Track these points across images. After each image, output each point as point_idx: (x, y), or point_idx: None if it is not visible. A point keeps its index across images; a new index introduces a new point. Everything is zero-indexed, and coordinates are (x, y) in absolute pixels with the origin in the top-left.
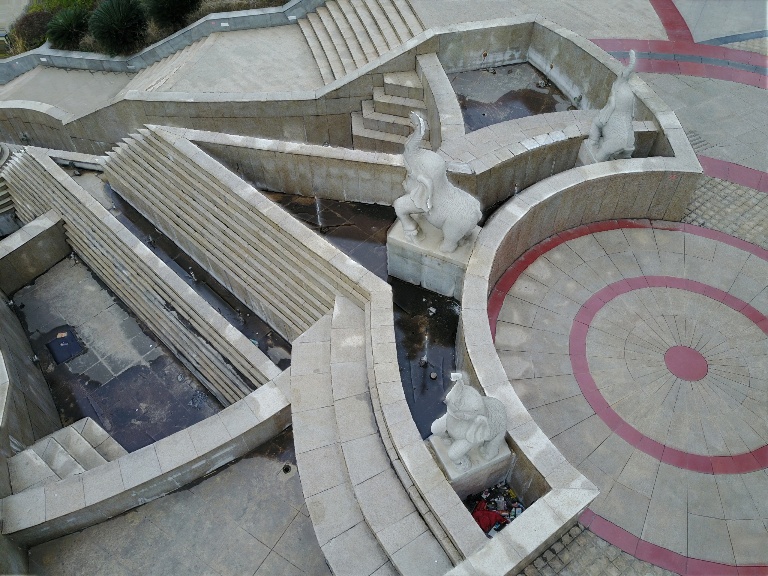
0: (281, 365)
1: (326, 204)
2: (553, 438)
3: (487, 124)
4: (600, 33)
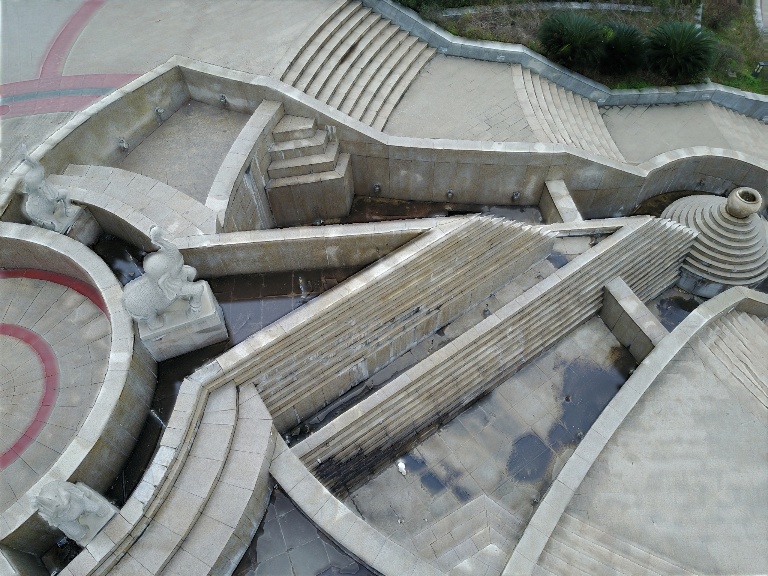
0: None
1: None
2: (37, 294)
3: None
4: None
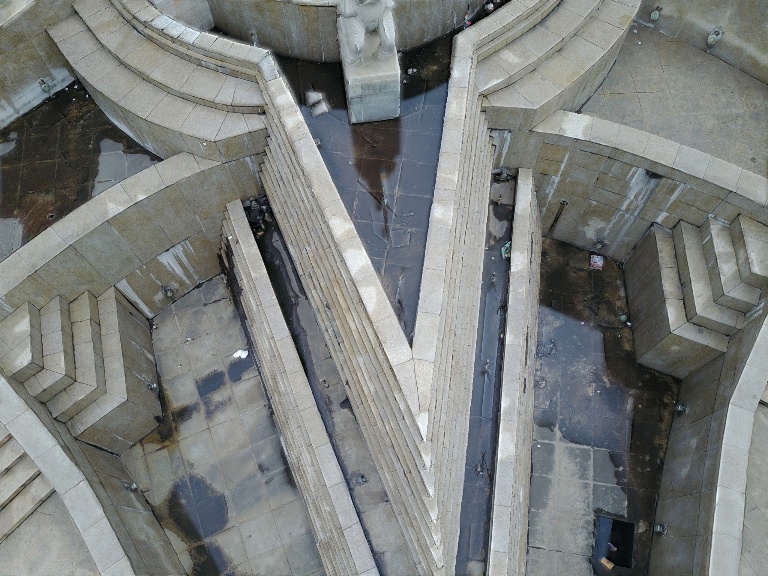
0: (505, 216)
1: None
2: None
3: (72, 203)
4: None
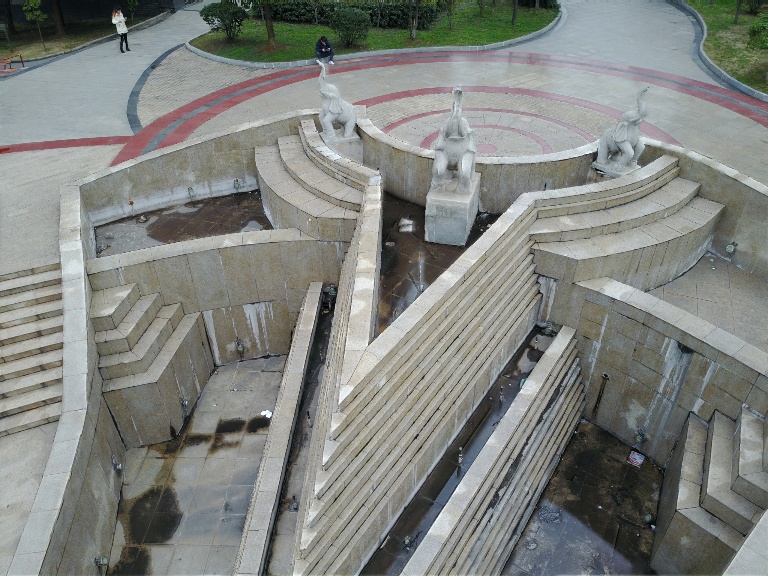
0: (537, 359)
1: (385, 294)
2: None
3: None
4: (96, 170)
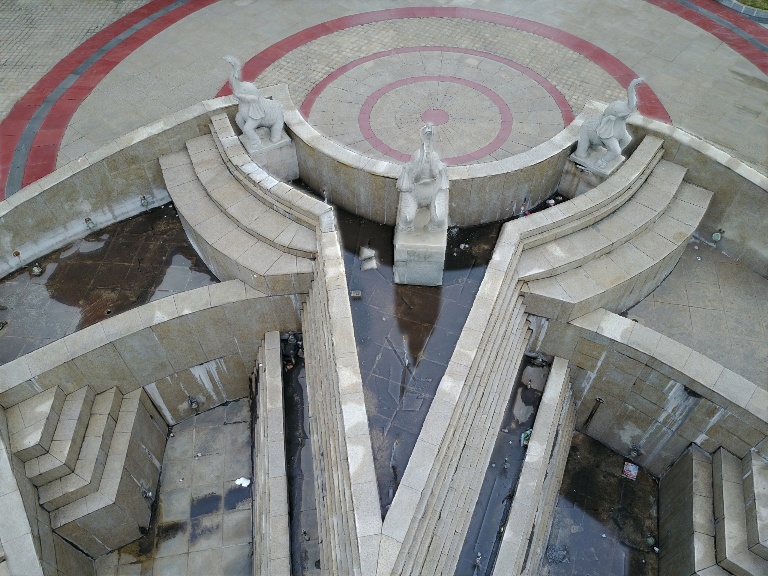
0: (532, 402)
1: (366, 377)
2: None
3: (130, 304)
4: None
